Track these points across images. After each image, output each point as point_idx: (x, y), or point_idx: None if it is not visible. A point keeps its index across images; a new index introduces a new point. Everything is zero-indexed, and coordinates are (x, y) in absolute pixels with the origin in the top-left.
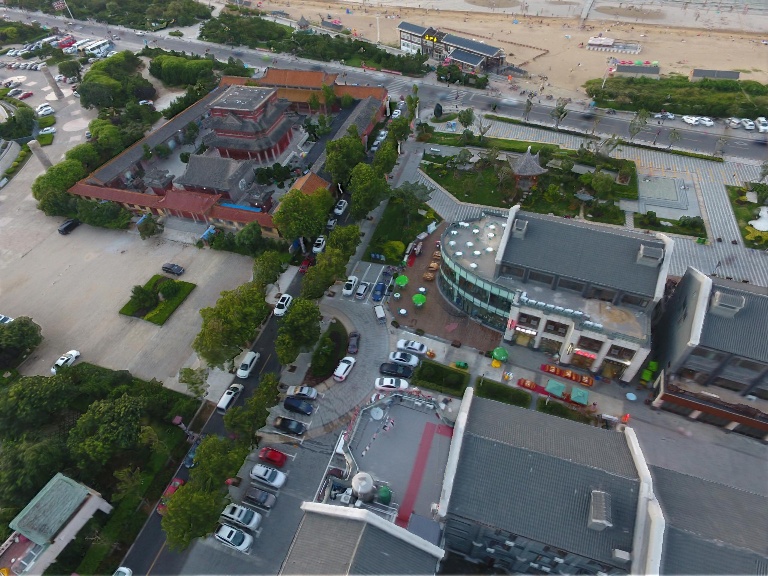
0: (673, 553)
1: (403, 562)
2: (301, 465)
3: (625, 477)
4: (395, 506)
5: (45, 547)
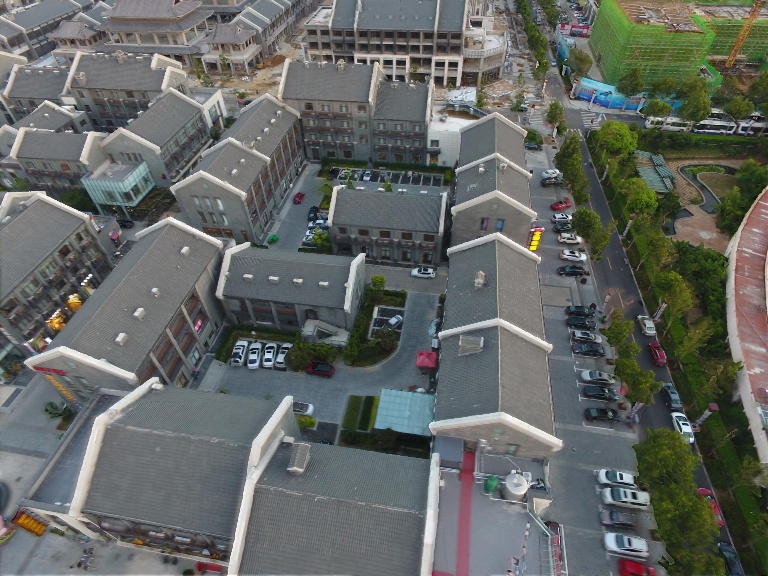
0: (253, 433)
1: (461, 408)
2: (598, 568)
3: (268, 487)
4: (478, 480)
5: (765, 424)
